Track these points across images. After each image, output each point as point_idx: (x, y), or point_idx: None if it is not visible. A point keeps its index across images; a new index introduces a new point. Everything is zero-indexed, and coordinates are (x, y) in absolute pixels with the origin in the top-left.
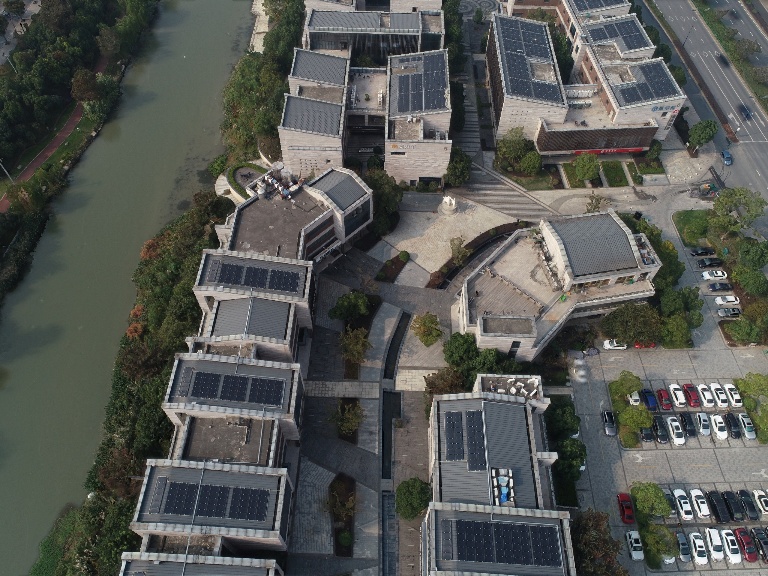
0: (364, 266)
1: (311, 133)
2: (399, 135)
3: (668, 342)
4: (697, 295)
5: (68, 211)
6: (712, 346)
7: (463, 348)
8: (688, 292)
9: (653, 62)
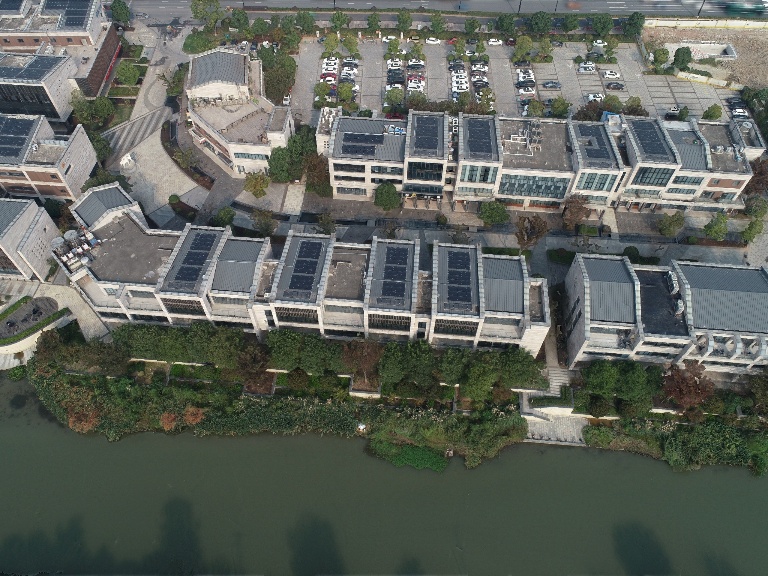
0: (174, 229)
1: (17, 219)
2: (50, 160)
3: None
4: None
5: None
6: (296, 61)
7: (285, 153)
8: None
9: (45, 0)
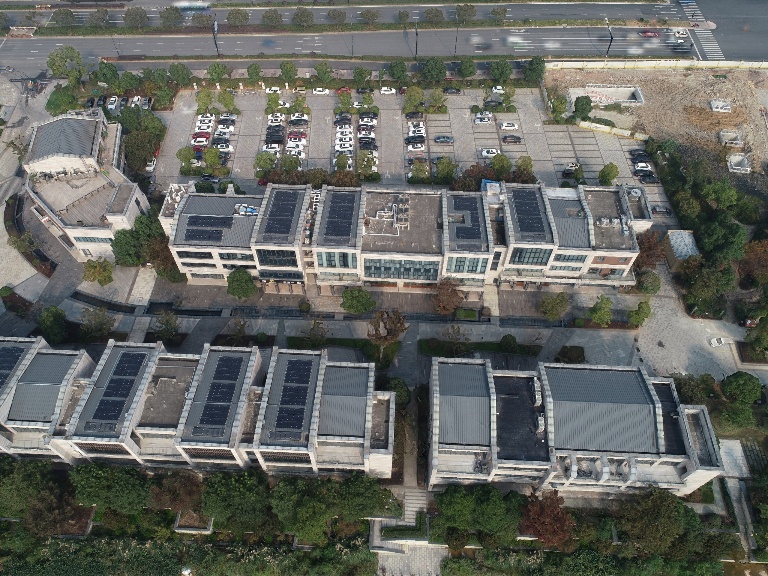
0: (2, 328)
1: None
2: None
3: (159, 138)
4: (129, 107)
5: None
6: (169, 119)
7: (129, 237)
8: (126, 109)
9: None
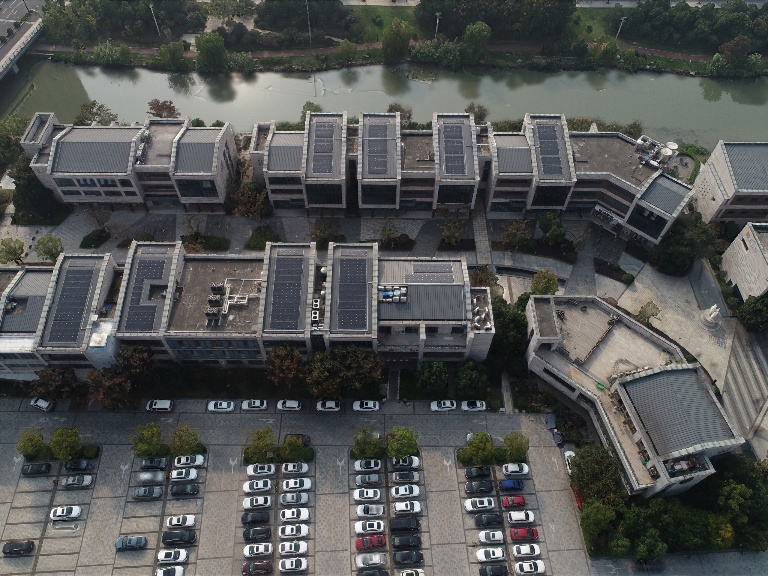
0: (608, 251)
1: (728, 166)
2: (766, 236)
3: None
4: (654, 552)
5: (606, 78)
6: None
7: (522, 296)
8: None
9: None
